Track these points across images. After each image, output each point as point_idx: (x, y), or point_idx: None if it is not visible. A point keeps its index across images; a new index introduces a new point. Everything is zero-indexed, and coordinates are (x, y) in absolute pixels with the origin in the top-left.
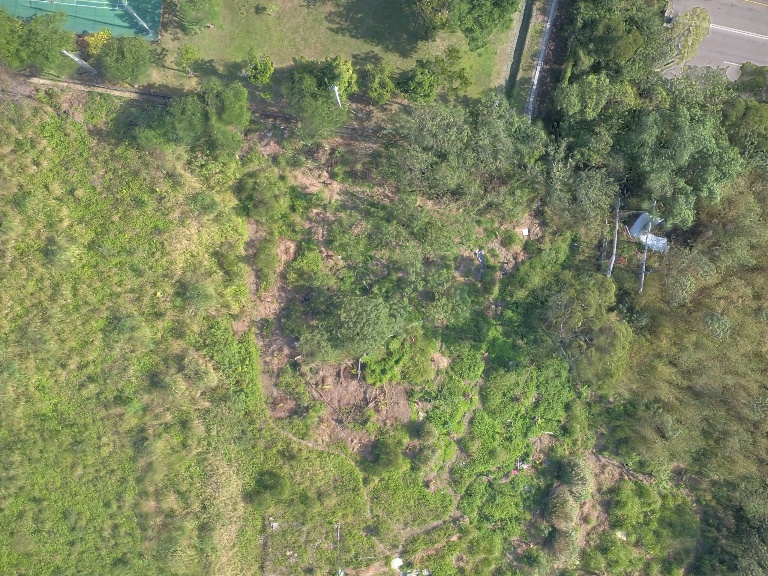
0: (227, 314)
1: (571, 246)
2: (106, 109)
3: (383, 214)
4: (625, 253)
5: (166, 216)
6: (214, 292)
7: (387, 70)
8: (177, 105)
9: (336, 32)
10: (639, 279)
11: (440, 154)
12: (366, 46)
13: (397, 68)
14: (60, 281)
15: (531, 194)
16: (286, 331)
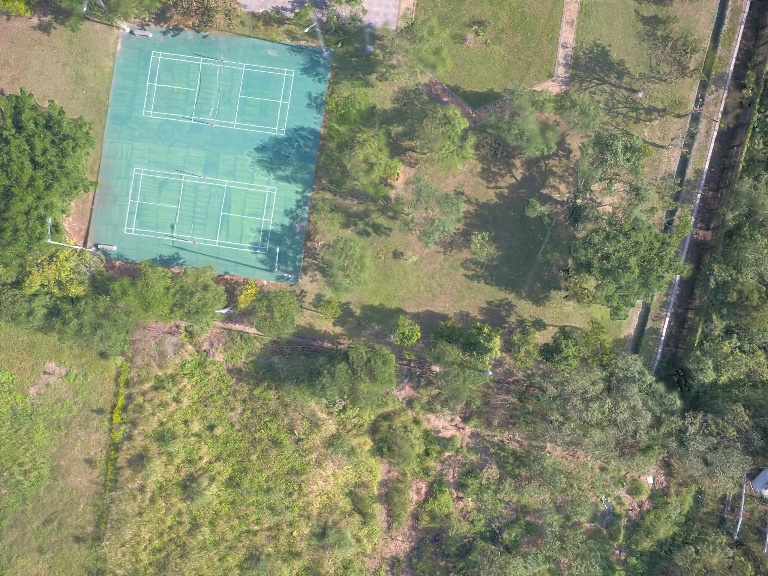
0: (359, 552)
1: (694, 496)
2: (246, 351)
3: (513, 460)
4: (746, 505)
5: (303, 457)
6: (350, 536)
7: (531, 338)
8: (331, 377)
9: (471, 279)
10: (763, 539)
11: (582, 427)
12: (500, 293)
13: (530, 316)
14: (197, 516)
15: (660, 450)
16: (416, 570)
